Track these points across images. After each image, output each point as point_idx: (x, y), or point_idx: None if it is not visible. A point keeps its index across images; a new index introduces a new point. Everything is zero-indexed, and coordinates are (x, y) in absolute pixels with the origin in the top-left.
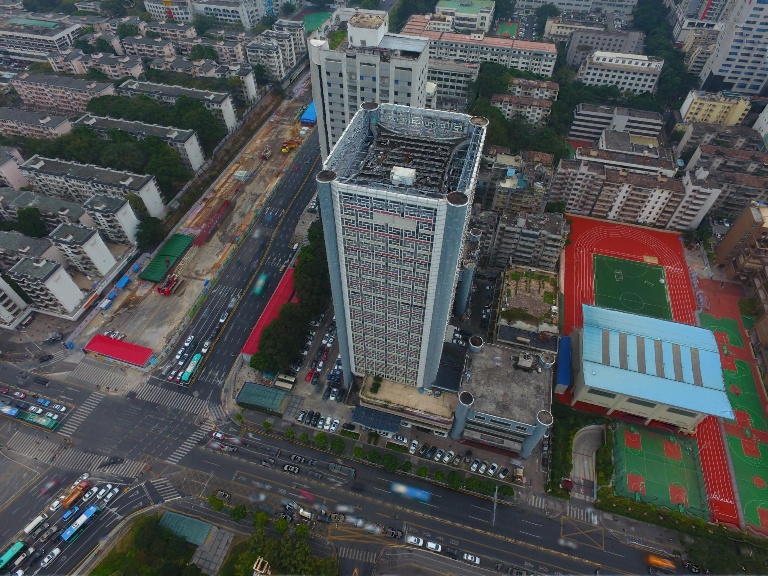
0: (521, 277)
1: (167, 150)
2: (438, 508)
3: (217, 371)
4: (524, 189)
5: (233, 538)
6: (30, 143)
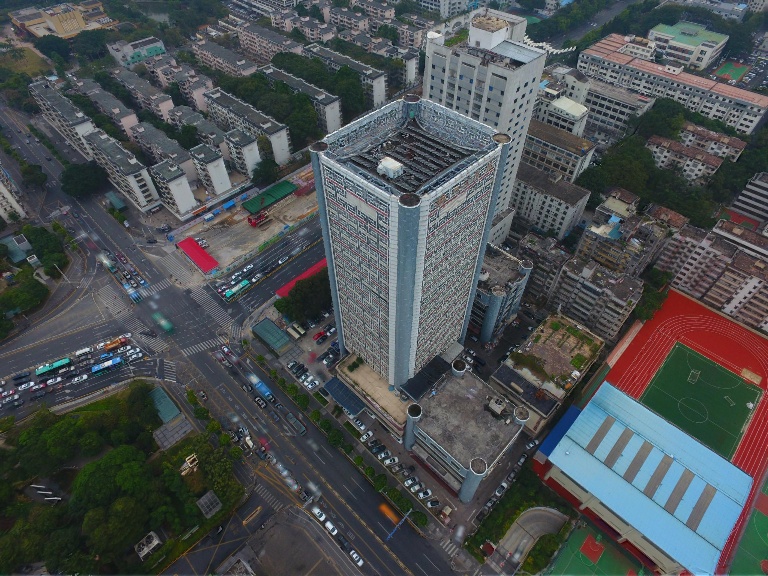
0: (561, 329)
1: (308, 108)
2: (355, 499)
3: (254, 300)
4: (615, 241)
5: (191, 431)
6: (222, 78)
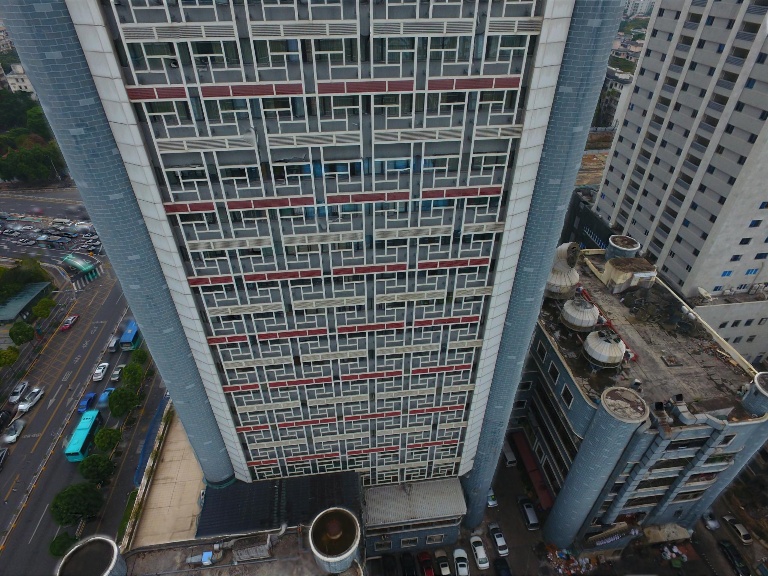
0: None
1: None
2: None
3: None
4: None
5: None
6: None
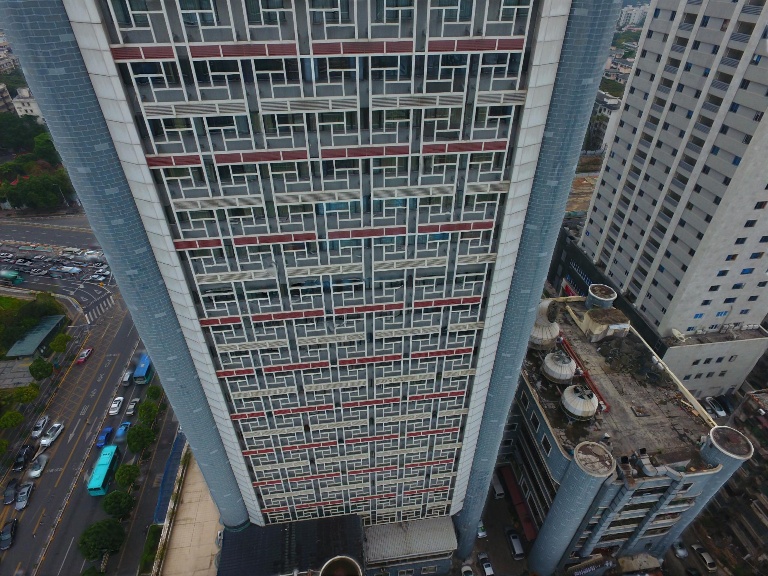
0: None
1: None
2: None
3: None
4: None
5: None
6: None
